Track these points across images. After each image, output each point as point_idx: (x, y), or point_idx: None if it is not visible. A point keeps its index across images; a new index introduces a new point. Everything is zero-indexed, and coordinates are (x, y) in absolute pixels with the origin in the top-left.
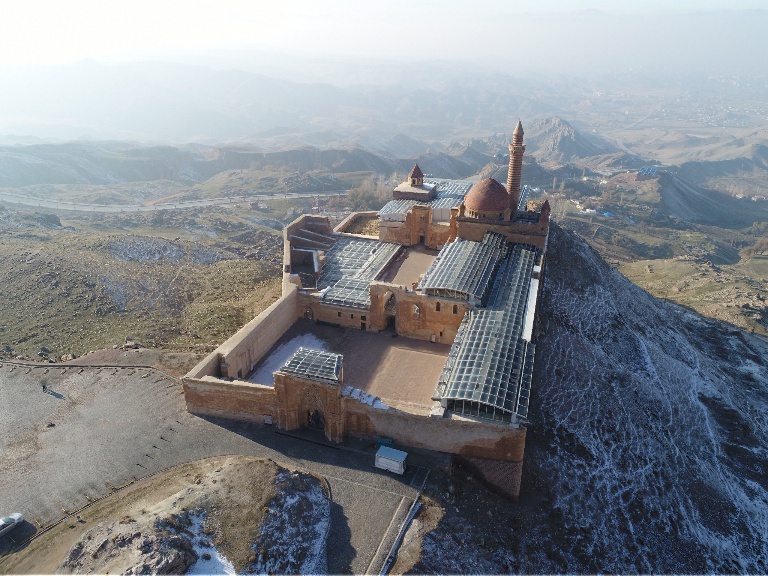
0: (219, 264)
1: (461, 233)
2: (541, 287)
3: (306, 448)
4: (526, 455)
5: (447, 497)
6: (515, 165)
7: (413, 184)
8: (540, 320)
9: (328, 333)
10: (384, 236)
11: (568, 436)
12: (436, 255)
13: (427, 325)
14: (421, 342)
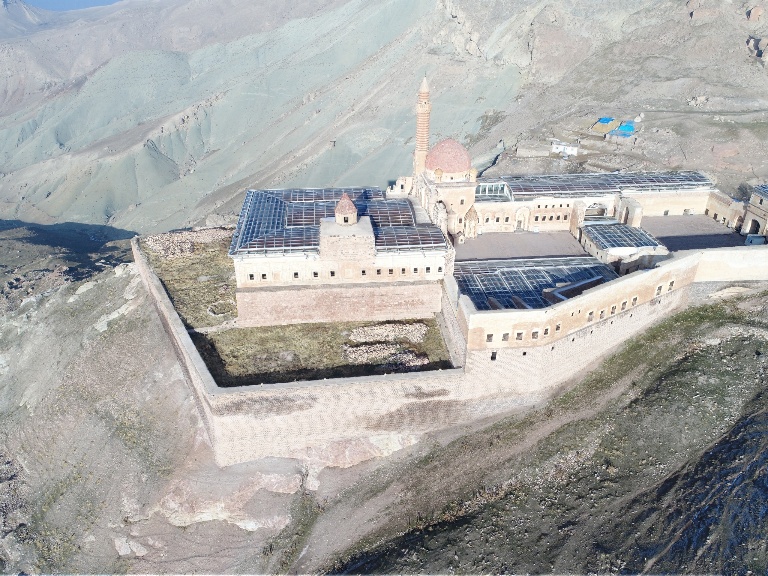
0: None
1: None
2: None
3: None
4: None
5: None
6: None
7: None
8: None
9: None
10: None
11: None
12: None
13: None
14: None
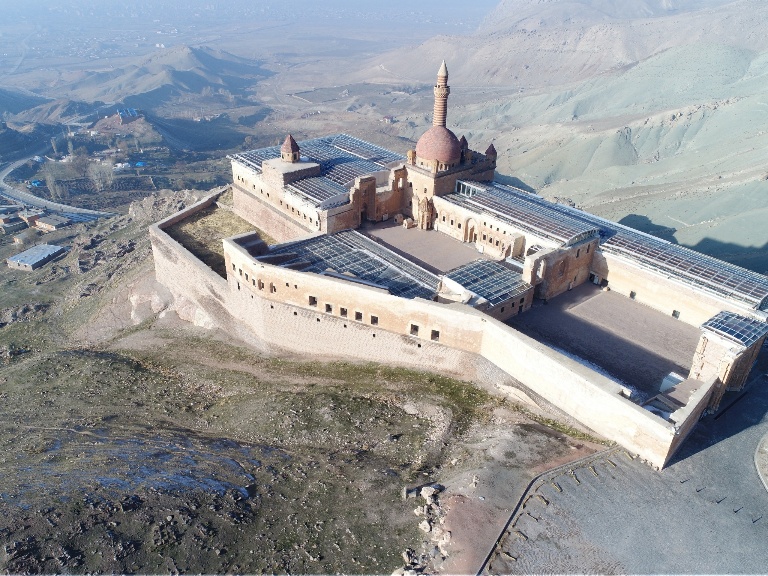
0: None
1: (437, 190)
2: None
3: (745, 409)
4: None
5: None
6: None
7: (294, 160)
8: None
9: None
10: (332, 227)
11: None
12: (393, 225)
13: (568, 276)
14: (566, 295)
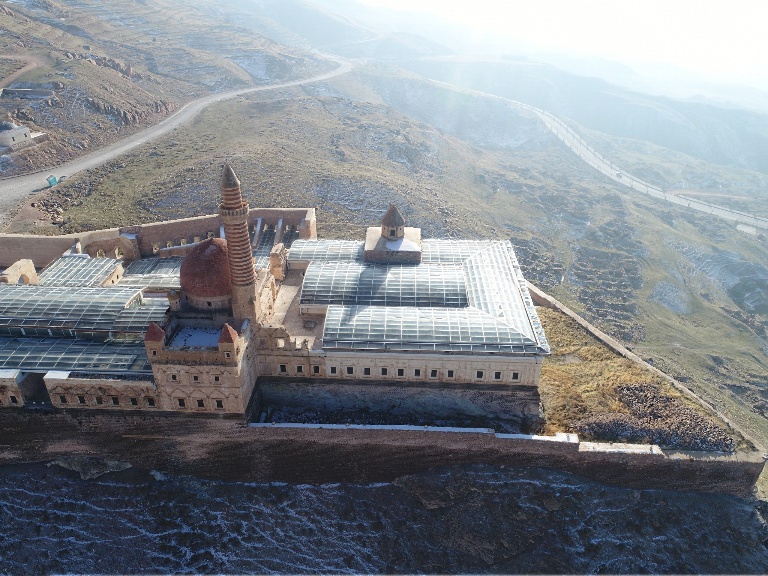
0: None
1: None
2: (206, 453)
3: None
4: None
5: None
6: None
7: None
8: (122, 469)
9: None
10: None
11: None
12: None
13: None
14: None
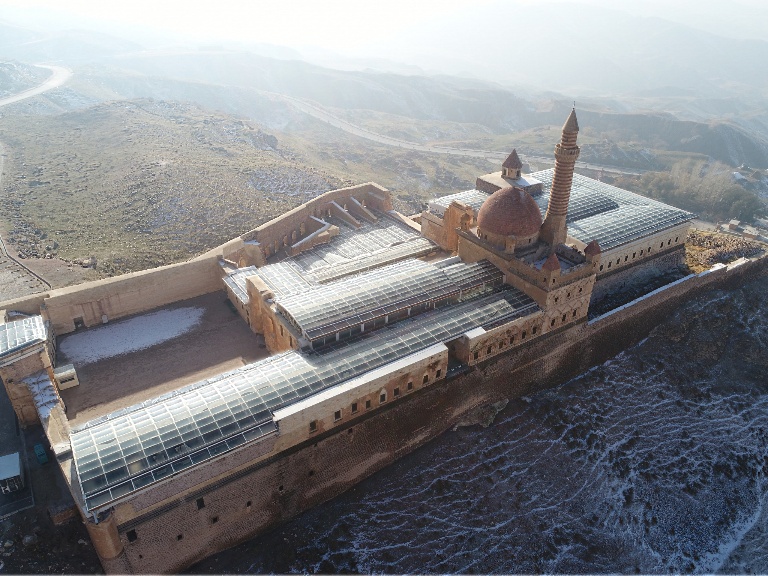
0: None
1: (461, 252)
2: (557, 363)
3: (2, 417)
4: (222, 560)
5: (4, 545)
6: (557, 176)
7: (504, 175)
8: (505, 406)
9: (217, 315)
10: (425, 230)
11: (343, 573)
12: None
13: (278, 348)
14: None
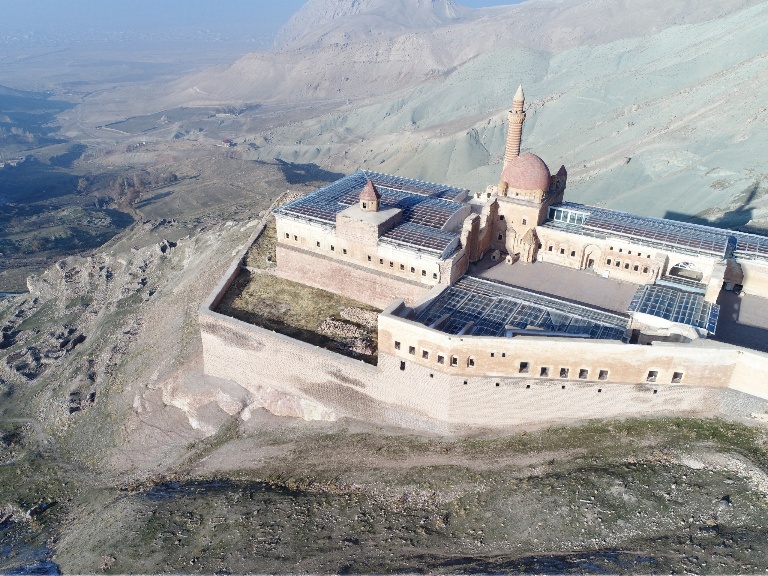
0: (112, 575)
1: None
2: None
3: None
4: None
5: None
6: None
7: (377, 208)
8: None
9: None
10: (453, 277)
11: None
12: (495, 263)
13: None
14: None
